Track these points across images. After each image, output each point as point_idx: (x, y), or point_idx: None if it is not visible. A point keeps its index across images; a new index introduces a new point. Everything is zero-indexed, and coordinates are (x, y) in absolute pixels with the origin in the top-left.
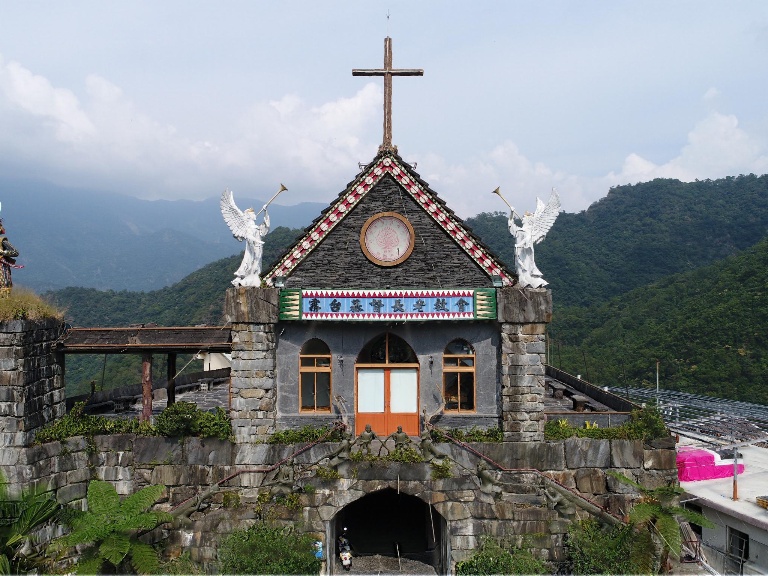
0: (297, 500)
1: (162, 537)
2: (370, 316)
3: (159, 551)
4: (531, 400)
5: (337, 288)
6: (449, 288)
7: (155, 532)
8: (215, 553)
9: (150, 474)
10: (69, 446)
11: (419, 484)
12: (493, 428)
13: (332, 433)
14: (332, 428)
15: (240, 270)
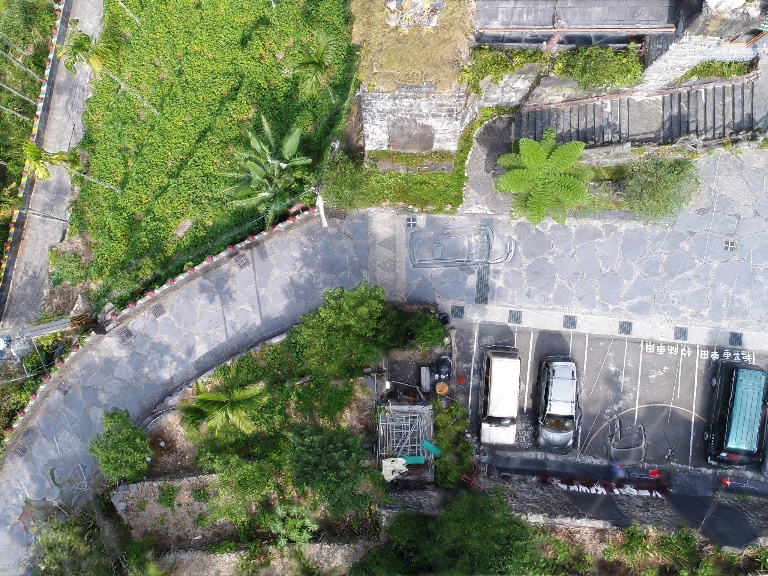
0: (696, 156)
1: (550, 108)
2: None
3: None
4: None
5: None
6: None
7: (544, 106)
8: (611, 160)
9: None
10: (482, 88)
11: None
12: None
13: (740, 68)
14: (742, 61)
15: None
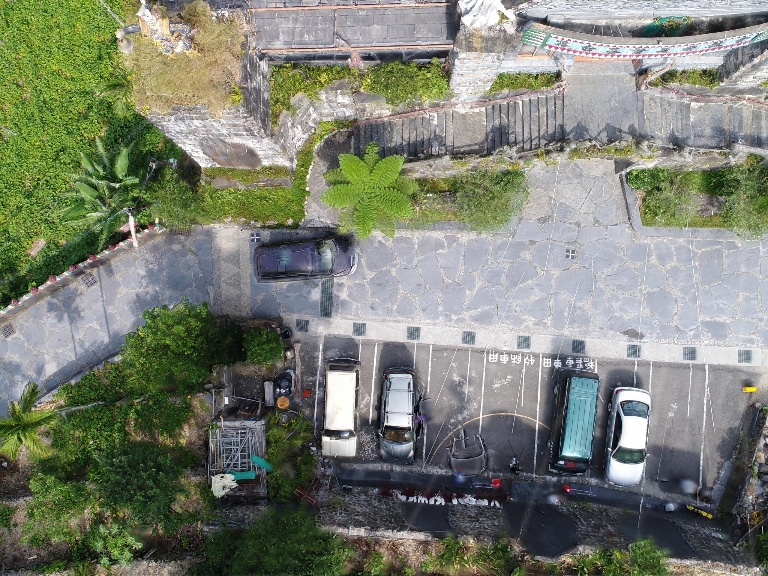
0: None
1: (383, 121)
2: (626, 57)
3: (411, 203)
4: (765, 72)
5: (593, 7)
6: (736, 30)
7: None
8: None
9: (370, 104)
10: (295, 105)
11: (623, 157)
12: (712, 68)
13: (548, 80)
14: (548, 72)
15: (474, 10)
